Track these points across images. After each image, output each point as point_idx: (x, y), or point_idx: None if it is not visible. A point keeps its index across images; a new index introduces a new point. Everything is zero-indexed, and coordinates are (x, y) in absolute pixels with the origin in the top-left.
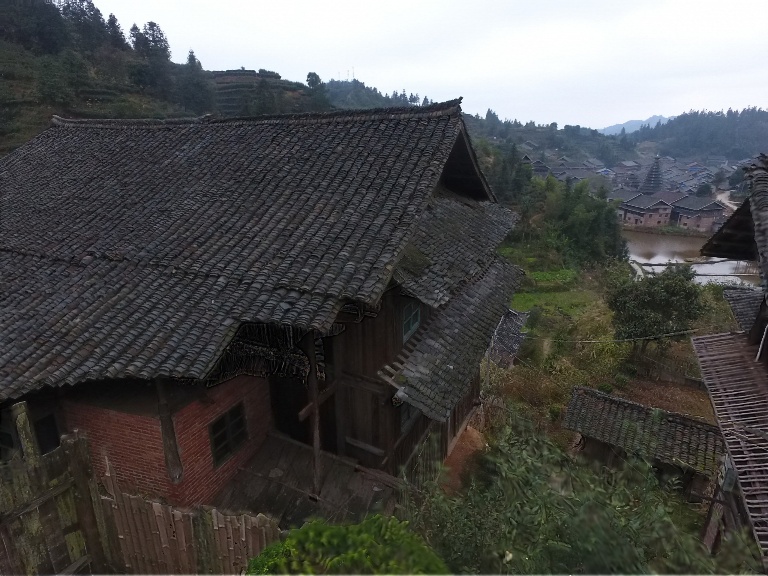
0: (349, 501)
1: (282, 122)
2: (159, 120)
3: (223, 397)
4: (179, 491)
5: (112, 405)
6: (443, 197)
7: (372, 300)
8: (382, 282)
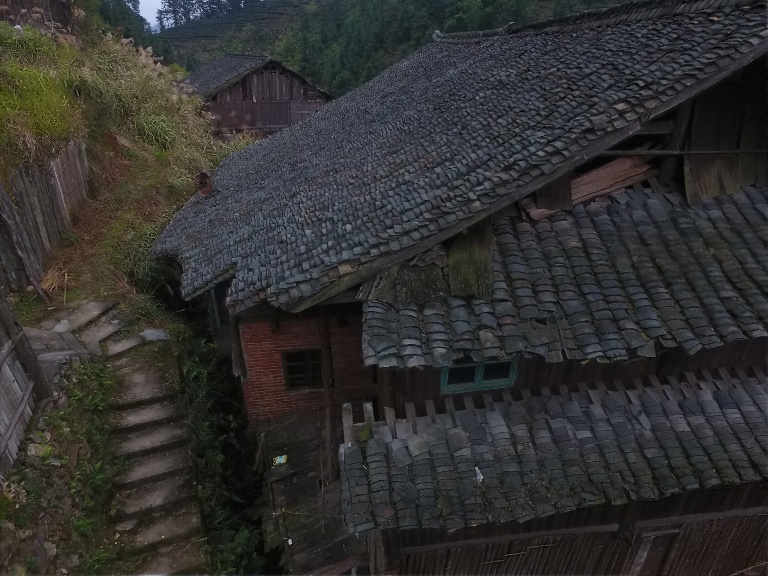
0: (330, 516)
1: (559, 29)
2: (479, 32)
3: (303, 333)
4: (244, 388)
5: None
6: None
7: (278, 302)
8: (312, 284)
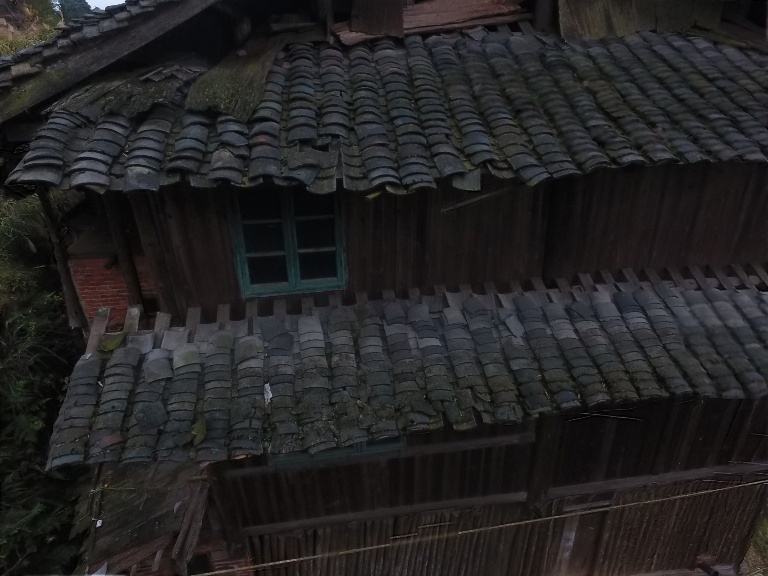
0: (152, 489)
1: None
2: None
3: None
4: None
5: (84, 234)
6: (694, 34)
7: None
8: None
